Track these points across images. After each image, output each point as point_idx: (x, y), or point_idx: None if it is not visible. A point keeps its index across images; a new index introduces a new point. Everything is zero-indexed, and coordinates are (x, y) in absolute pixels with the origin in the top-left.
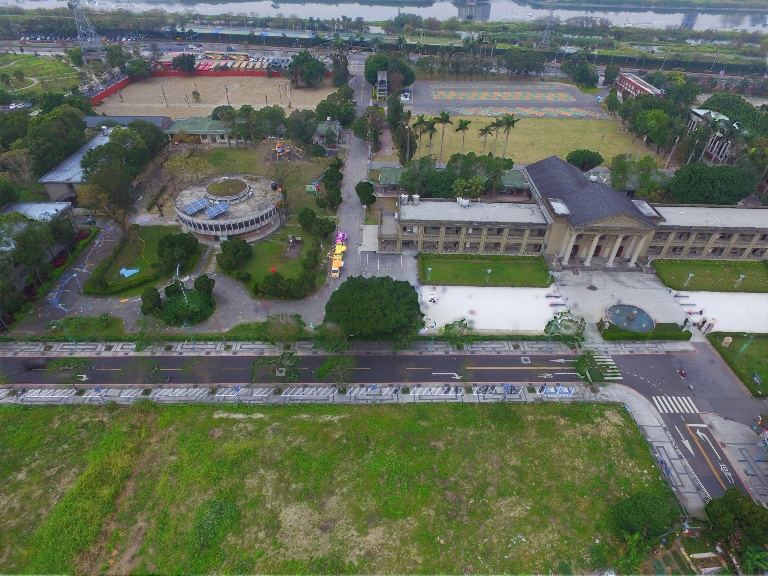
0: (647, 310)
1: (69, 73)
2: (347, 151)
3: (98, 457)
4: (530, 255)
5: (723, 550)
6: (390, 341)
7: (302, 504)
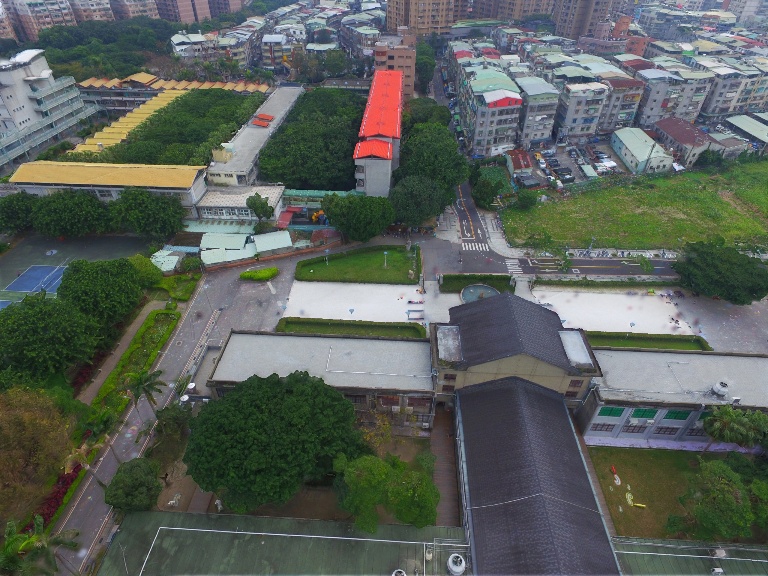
0: None
1: None
2: None
3: None
4: None
5: None
6: None
7: None
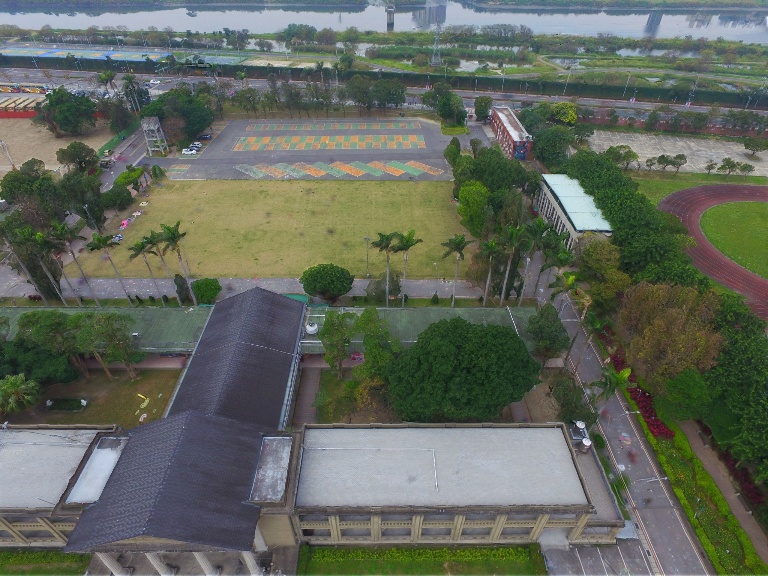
0: None
1: None
2: (7, 257)
3: None
4: None
5: None
6: None
7: None
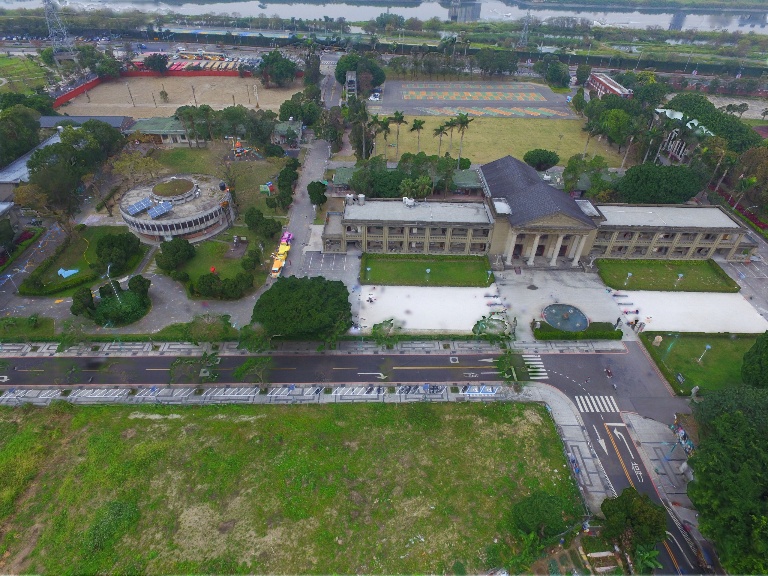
0: (584, 309)
1: (40, 73)
2: (308, 151)
3: (4, 458)
4: (475, 255)
5: (620, 549)
6: (320, 341)
7: (205, 505)
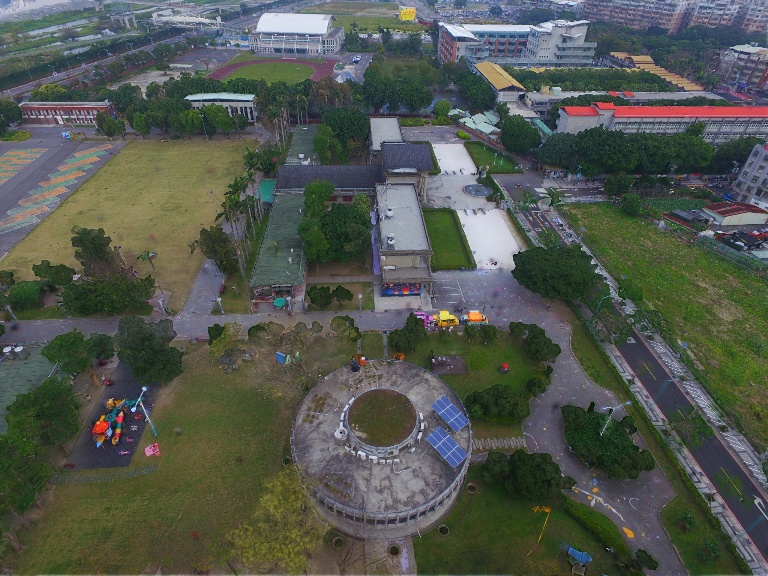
0: None
1: None
2: None
3: None
4: None
5: (620, 198)
6: None
7: None
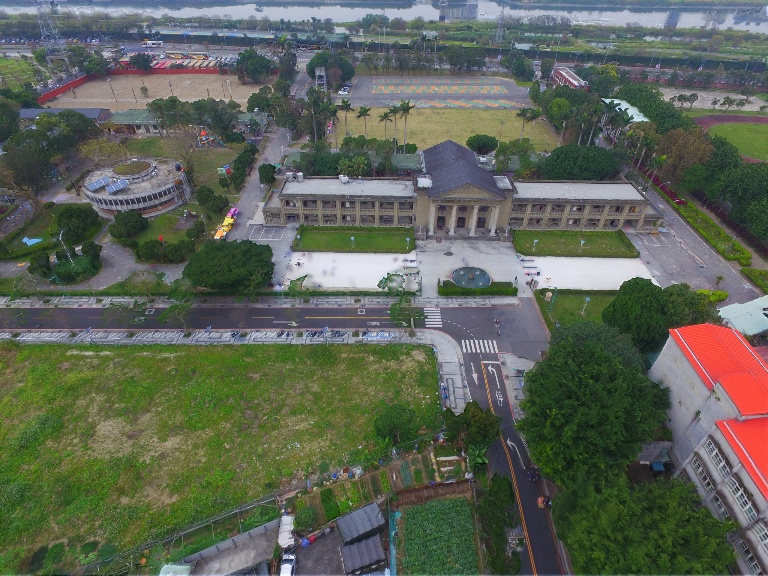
0: (490, 272)
1: (32, 72)
2: (270, 139)
3: None
4: (403, 227)
5: (465, 454)
6: (244, 296)
7: (119, 419)
